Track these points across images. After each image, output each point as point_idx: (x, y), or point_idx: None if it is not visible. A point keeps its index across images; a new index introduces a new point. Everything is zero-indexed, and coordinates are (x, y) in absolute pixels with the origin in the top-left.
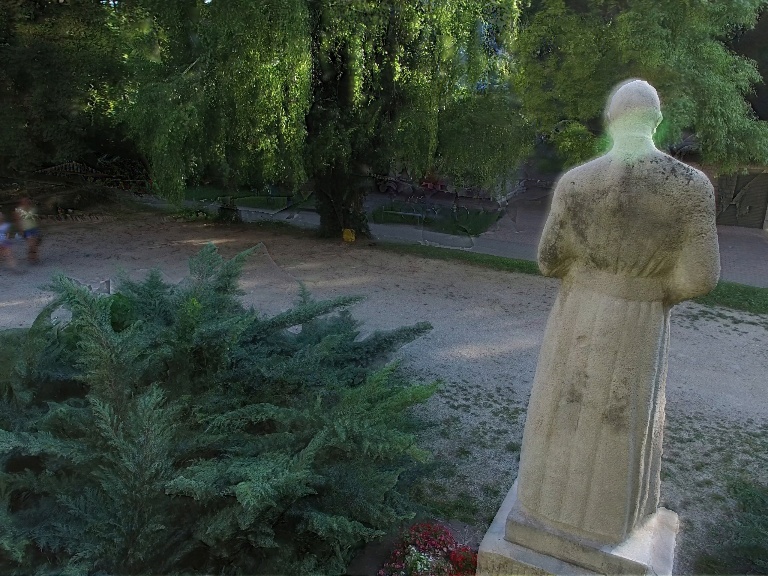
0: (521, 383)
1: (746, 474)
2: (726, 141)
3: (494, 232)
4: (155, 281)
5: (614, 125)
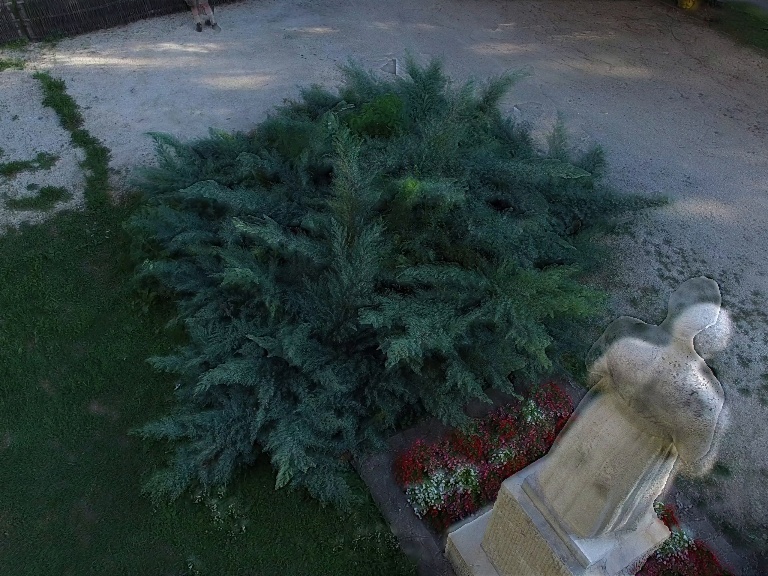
0: (754, 274)
1: None
2: None
3: None
4: (433, 69)
5: None
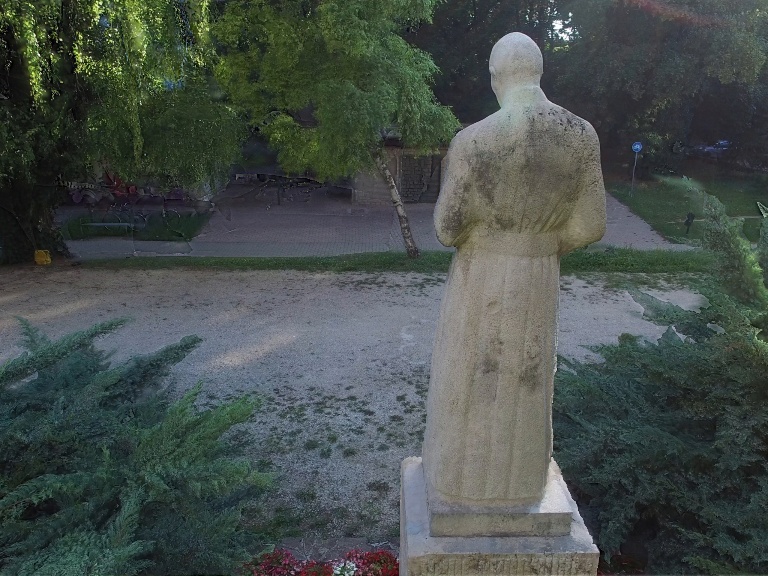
0: (296, 379)
1: None
2: (420, 125)
3: (206, 234)
4: None
5: (501, 79)
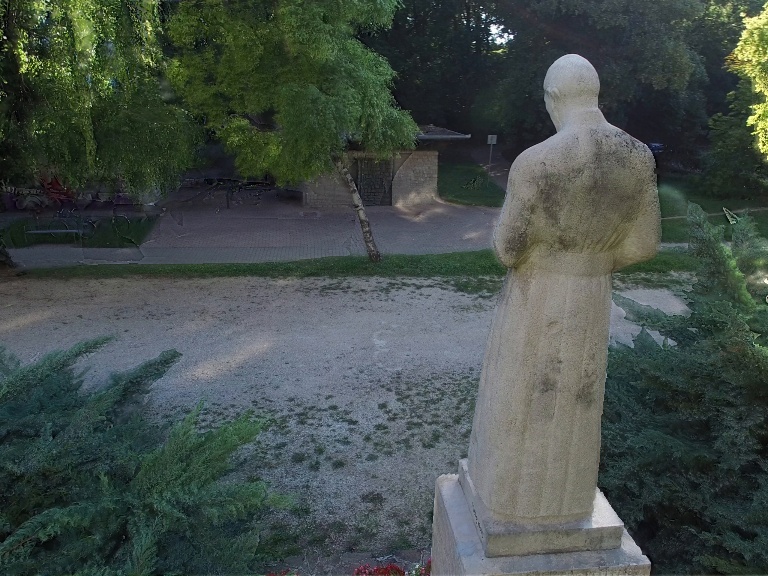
0: (273, 390)
1: None
2: (382, 129)
3: (154, 239)
4: None
5: (565, 101)
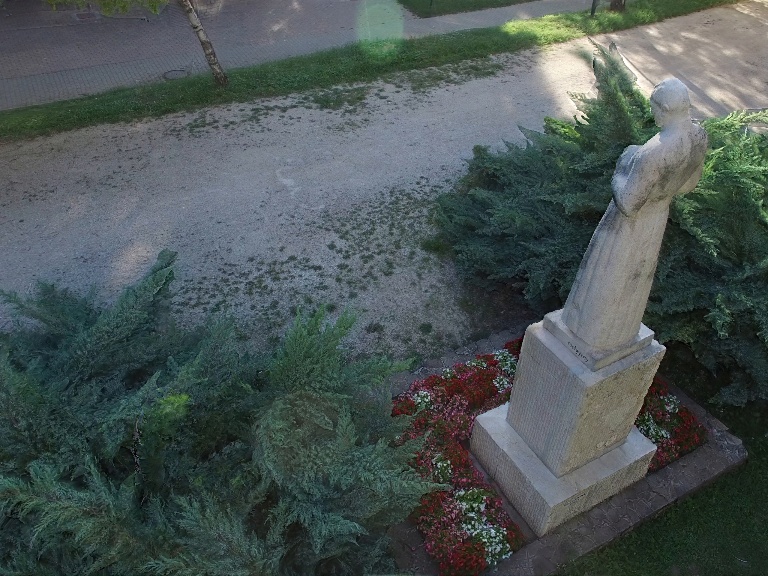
0: (229, 253)
1: (421, 234)
2: None
3: None
4: None
5: (672, 113)
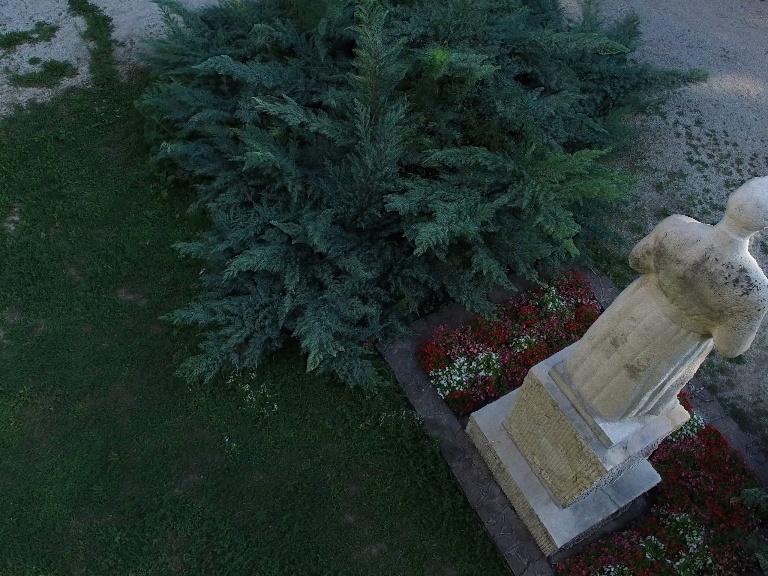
0: None
1: None
2: None
3: None
4: None
5: None
